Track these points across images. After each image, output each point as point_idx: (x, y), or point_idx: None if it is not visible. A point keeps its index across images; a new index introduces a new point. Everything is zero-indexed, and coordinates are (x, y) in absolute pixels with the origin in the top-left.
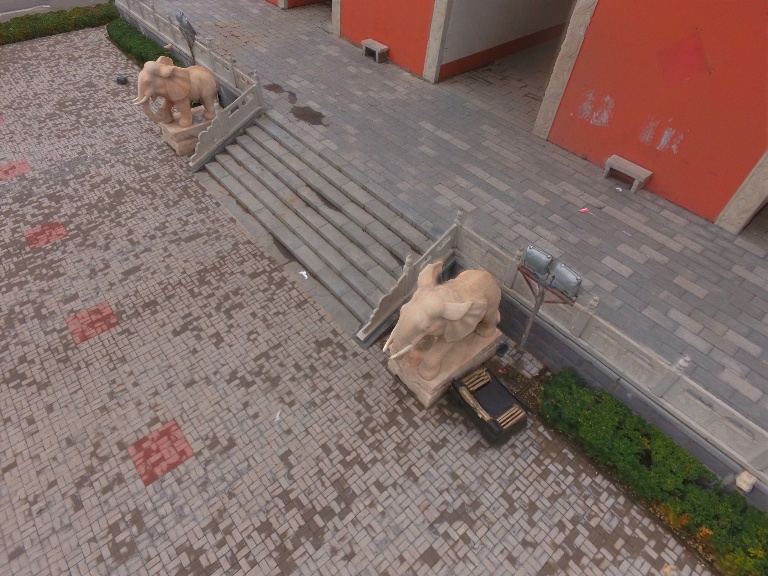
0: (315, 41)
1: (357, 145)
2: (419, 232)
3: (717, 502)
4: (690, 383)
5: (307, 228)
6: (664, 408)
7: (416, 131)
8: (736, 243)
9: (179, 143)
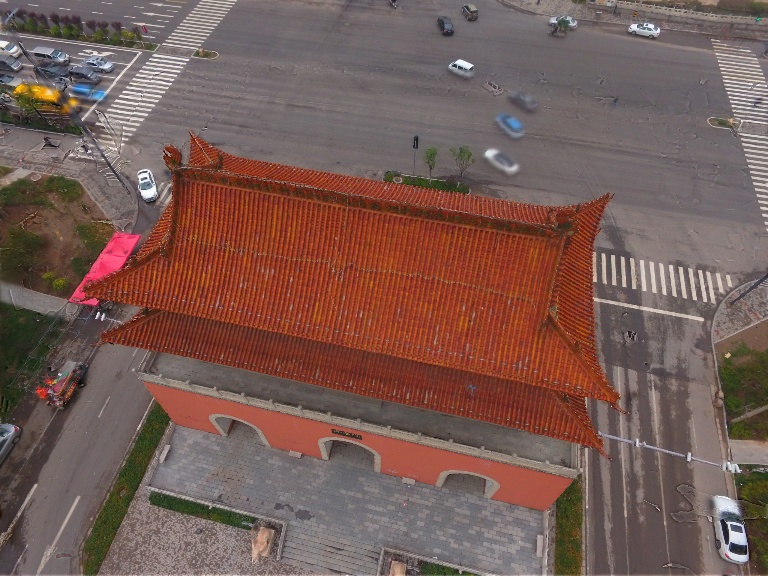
0: (264, 458)
1: (330, 520)
2: (371, 546)
3: (459, 575)
4: (445, 563)
5: (338, 561)
6: (443, 565)
7: (342, 498)
8: (442, 491)
9: (267, 555)
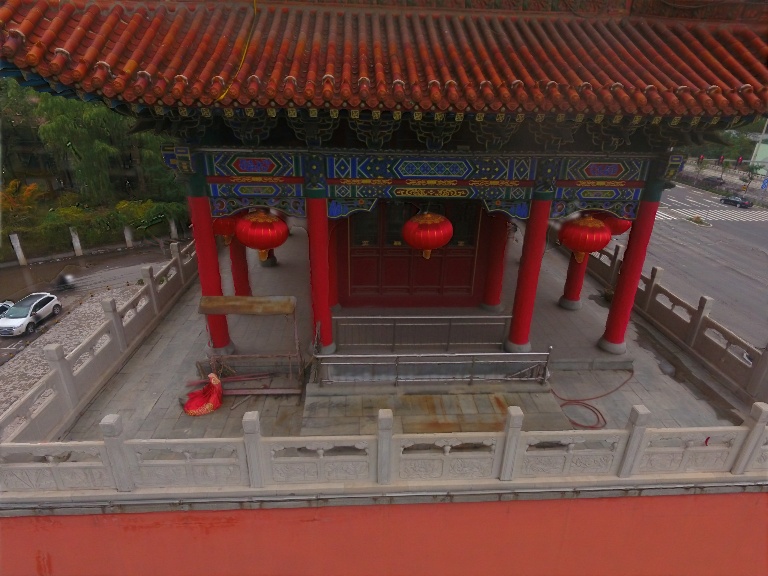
0: None
1: None
2: None
3: None
4: None
5: None
6: None
7: None
8: None
9: None
